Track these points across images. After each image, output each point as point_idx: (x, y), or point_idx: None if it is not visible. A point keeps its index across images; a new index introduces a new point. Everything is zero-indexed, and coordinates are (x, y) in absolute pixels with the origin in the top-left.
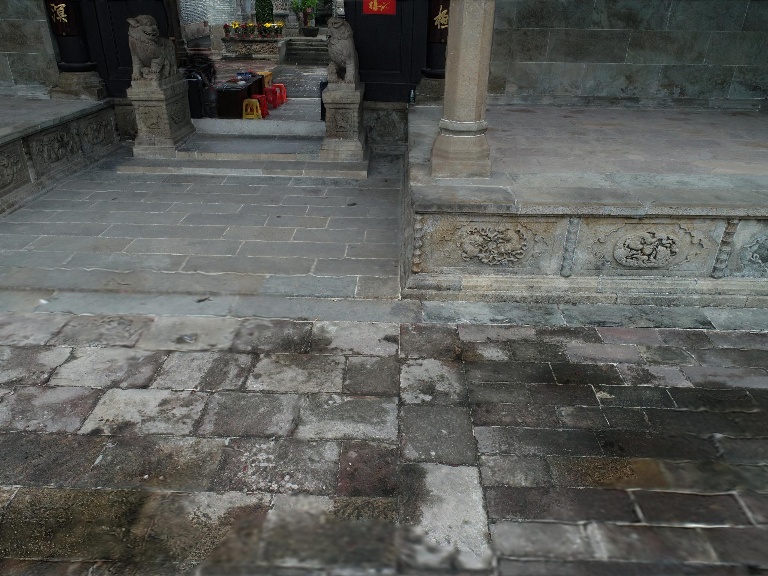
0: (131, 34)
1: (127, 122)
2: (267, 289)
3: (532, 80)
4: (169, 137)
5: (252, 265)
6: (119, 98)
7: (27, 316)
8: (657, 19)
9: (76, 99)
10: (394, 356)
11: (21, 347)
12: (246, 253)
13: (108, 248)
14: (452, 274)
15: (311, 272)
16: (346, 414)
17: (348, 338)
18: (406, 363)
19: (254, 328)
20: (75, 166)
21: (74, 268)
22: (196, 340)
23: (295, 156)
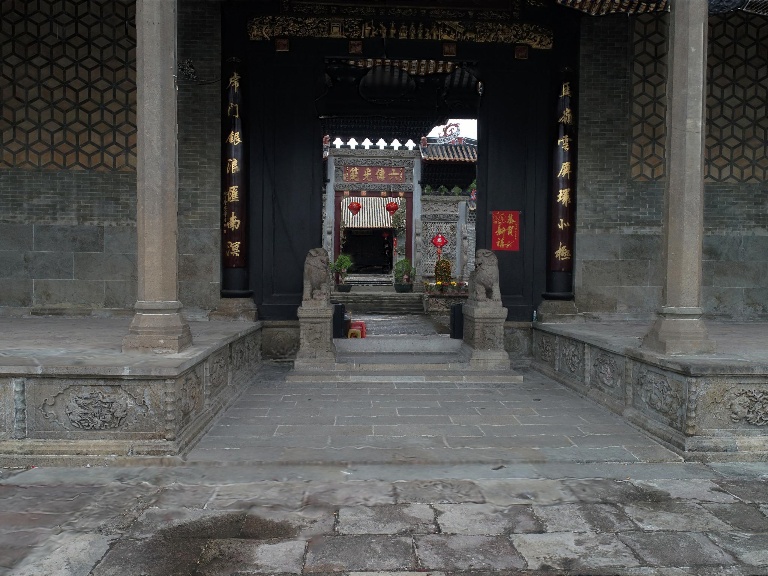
0: (309, 262)
1: (271, 342)
2: (554, 457)
3: (639, 301)
4: (329, 350)
5: (513, 441)
6: (269, 321)
7: (346, 483)
8: (733, 252)
9: (233, 321)
10: (740, 502)
11: (372, 506)
12: (493, 433)
13: (357, 432)
14: (723, 436)
15: (575, 444)
16: (764, 545)
17: (678, 491)
18: (761, 506)
19: (582, 485)
20: (246, 376)
21: (345, 447)
22: (535, 497)
23: (447, 366)
